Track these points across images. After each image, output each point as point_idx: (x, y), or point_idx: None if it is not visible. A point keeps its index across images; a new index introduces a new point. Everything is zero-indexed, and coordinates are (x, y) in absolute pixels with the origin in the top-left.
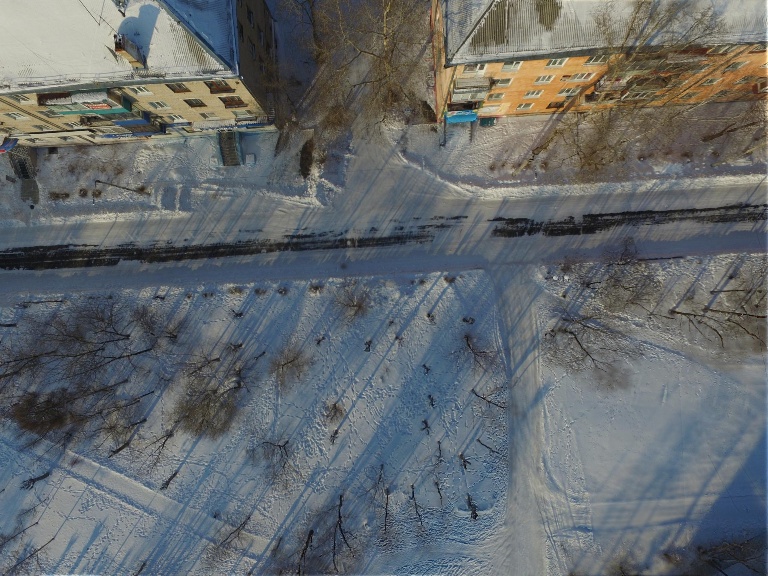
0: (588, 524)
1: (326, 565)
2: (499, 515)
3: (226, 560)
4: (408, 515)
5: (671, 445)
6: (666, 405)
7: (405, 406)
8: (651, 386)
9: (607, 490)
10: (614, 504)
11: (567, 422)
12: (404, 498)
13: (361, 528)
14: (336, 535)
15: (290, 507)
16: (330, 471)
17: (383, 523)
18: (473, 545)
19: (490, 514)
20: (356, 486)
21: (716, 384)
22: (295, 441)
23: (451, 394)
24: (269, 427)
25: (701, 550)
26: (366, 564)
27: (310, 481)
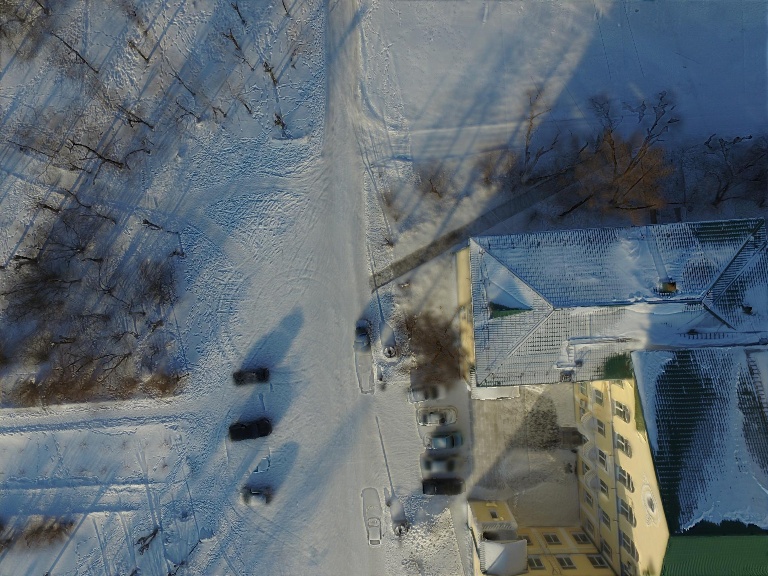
0: (407, 154)
1: (137, 200)
2: (316, 146)
3: (34, 196)
4: (221, 147)
5: (492, 66)
6: (487, 24)
7: (218, 32)
8: (471, 5)
9: (427, 117)
10: (434, 132)
11: (385, 45)
12: (217, 128)
13: (172, 160)
14: (146, 168)
15: (100, 140)
16: (141, 102)
17: (196, 156)
18: (289, 178)
19: (306, 145)
20: (167, 117)
21: (538, 1)
22: (105, 71)
23: (264, 17)
24: (78, 57)
25: (522, 173)
26: (178, 199)
27: (120, 113)
